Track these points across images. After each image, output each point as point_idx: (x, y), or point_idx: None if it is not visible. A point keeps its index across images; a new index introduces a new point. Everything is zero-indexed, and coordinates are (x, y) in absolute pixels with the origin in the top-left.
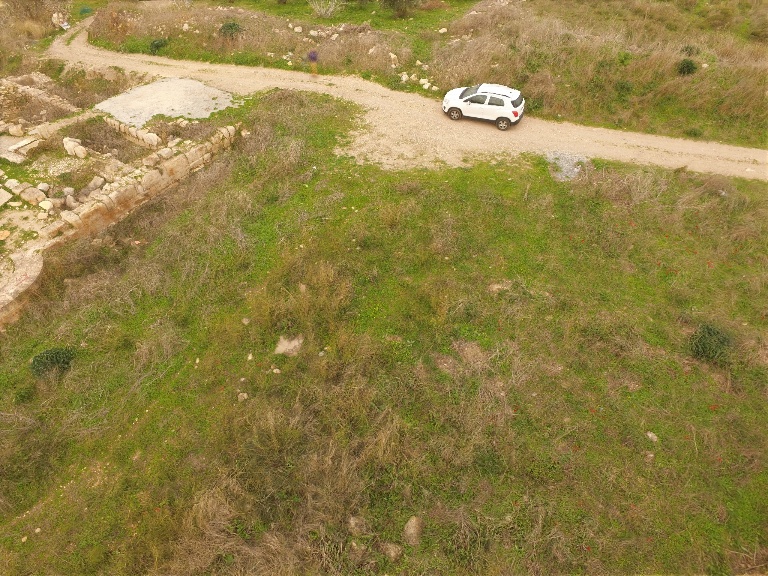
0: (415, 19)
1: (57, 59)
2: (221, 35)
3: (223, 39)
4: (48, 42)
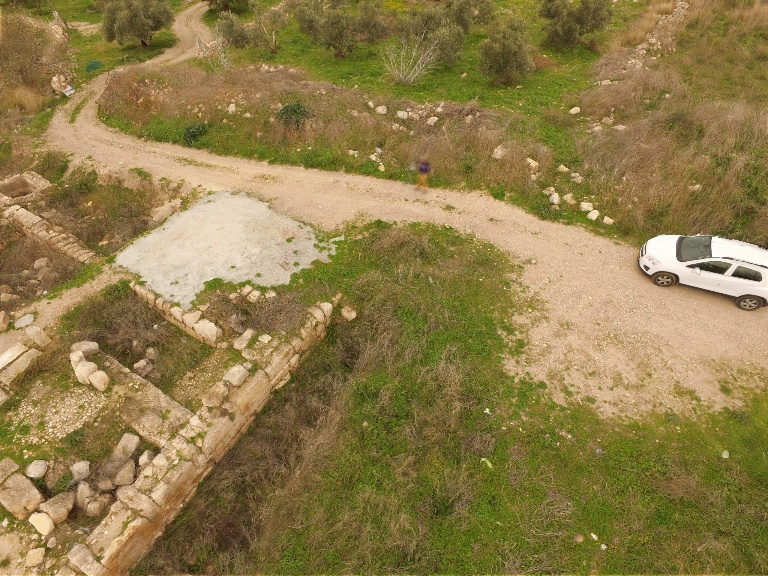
0: (524, 87)
1: (58, 152)
2: (282, 123)
3: (285, 128)
4: (46, 118)
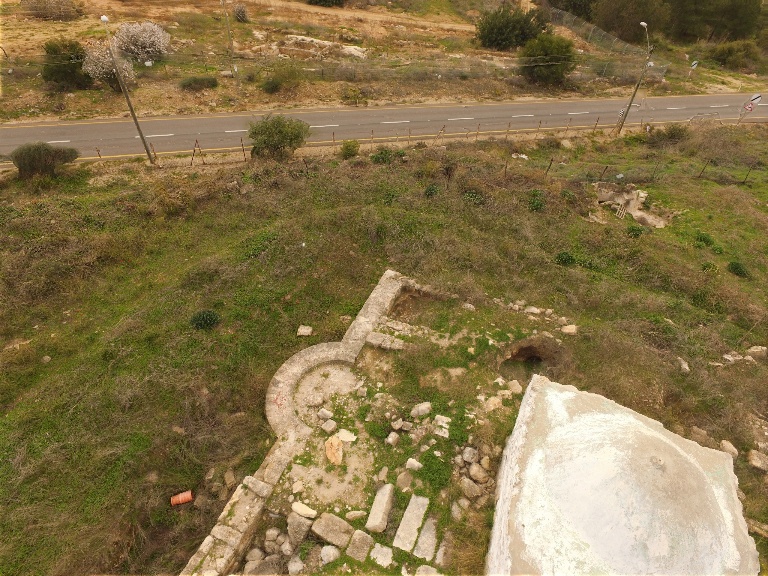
0: None
1: None
2: None
3: None
4: None
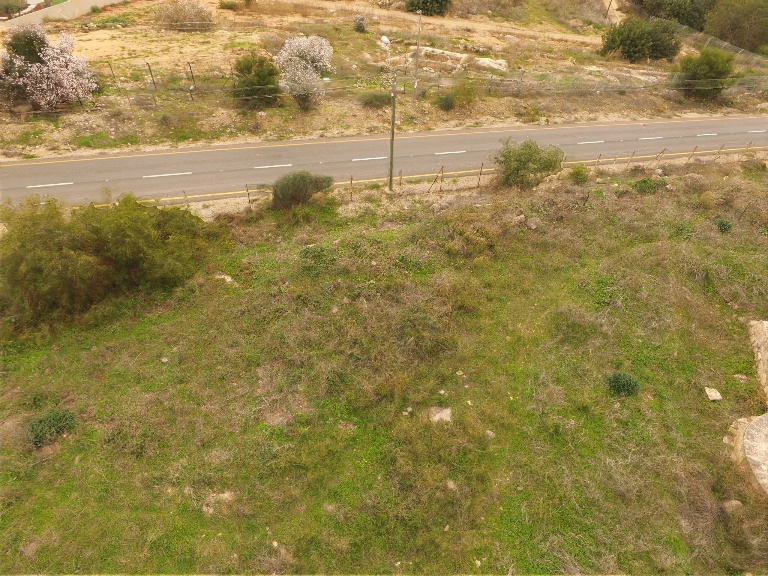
0: None
1: None
2: None
3: None
4: None
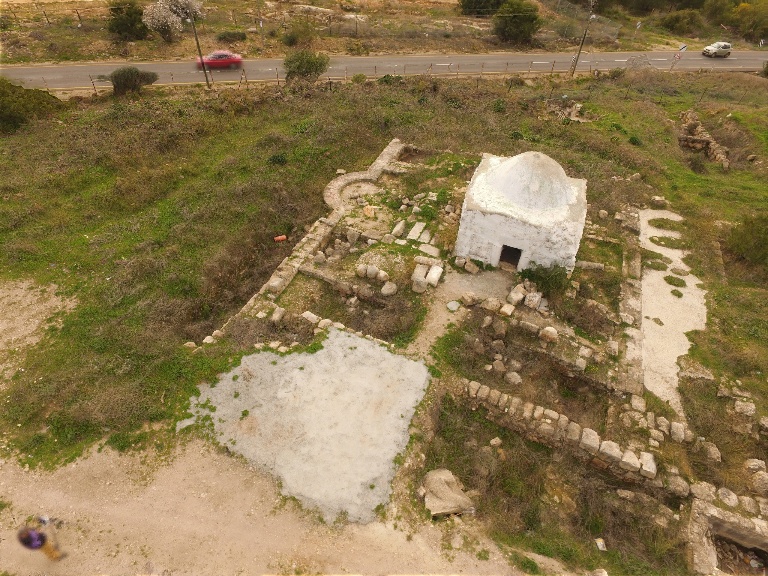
0: None
1: None
2: None
3: None
4: None
